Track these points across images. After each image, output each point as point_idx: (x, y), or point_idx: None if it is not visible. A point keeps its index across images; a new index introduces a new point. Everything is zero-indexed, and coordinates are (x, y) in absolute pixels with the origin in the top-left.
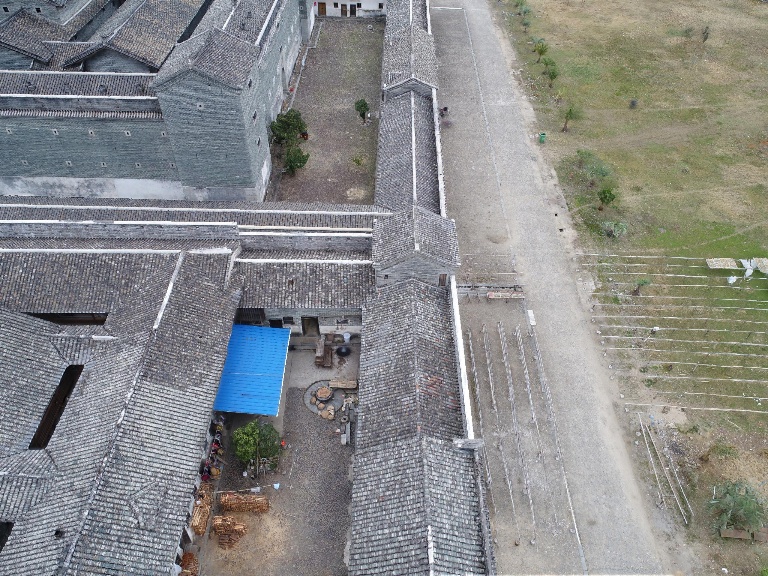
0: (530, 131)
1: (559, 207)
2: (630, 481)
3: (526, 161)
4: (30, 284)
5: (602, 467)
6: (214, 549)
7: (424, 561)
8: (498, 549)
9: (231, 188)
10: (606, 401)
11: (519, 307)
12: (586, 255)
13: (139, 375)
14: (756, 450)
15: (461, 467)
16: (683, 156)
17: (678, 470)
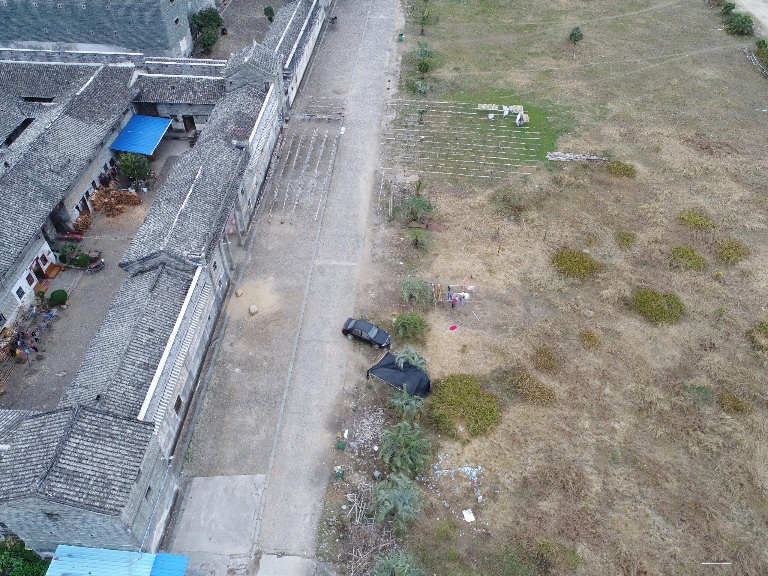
0: (395, 34)
1: (393, 77)
2: (366, 203)
3: (383, 51)
4: (8, 80)
5: (352, 197)
6: (103, 217)
7: (193, 178)
8: (270, 225)
9: (155, 50)
10: (371, 170)
11: (336, 125)
12: (398, 102)
13: (63, 112)
14: (455, 194)
15: (235, 155)
16: (503, 52)
17: (399, 200)
